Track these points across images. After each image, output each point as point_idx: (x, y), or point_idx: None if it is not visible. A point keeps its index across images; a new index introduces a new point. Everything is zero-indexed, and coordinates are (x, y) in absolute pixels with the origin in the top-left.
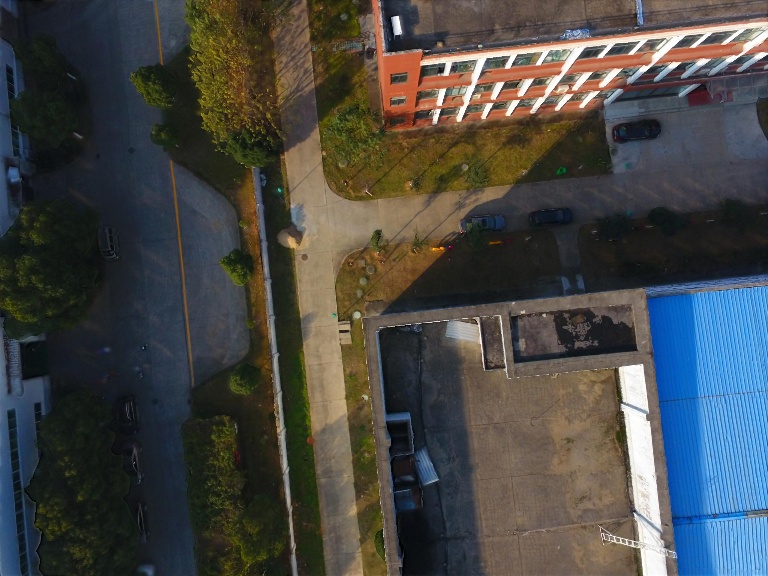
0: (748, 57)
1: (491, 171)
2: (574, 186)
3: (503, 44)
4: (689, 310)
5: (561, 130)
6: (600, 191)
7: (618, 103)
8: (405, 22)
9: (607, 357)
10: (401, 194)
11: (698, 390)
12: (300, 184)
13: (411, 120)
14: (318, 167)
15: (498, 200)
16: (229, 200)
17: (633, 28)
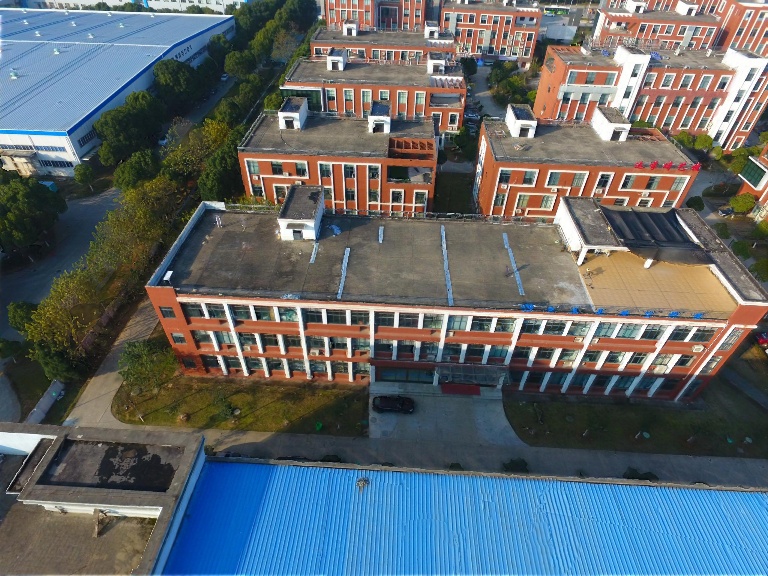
0: (459, 349)
1: (258, 418)
2: (330, 443)
3: (238, 296)
4: (264, 480)
5: (330, 395)
6: (353, 451)
7: (382, 382)
8: (179, 277)
9: (131, 493)
10: (170, 424)
11: (235, 572)
12: (88, 402)
13: (201, 365)
14: (112, 392)
15: (255, 444)
16: (22, 409)
17: (331, 299)
